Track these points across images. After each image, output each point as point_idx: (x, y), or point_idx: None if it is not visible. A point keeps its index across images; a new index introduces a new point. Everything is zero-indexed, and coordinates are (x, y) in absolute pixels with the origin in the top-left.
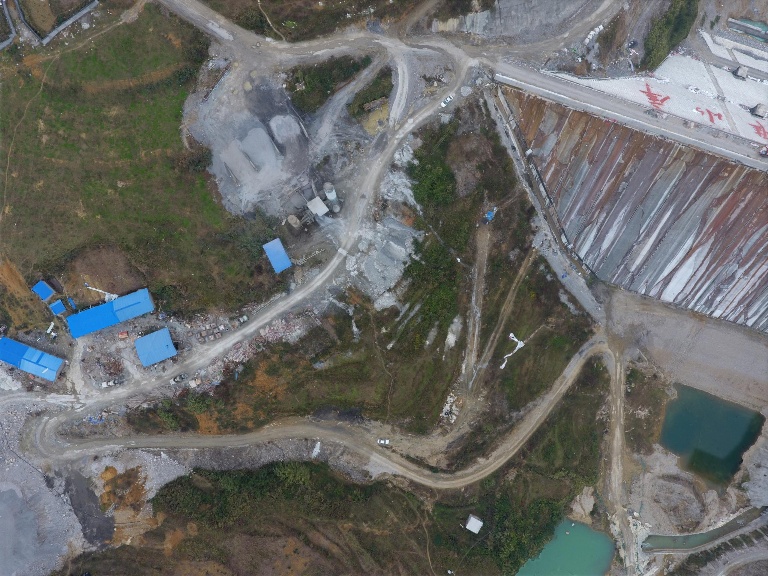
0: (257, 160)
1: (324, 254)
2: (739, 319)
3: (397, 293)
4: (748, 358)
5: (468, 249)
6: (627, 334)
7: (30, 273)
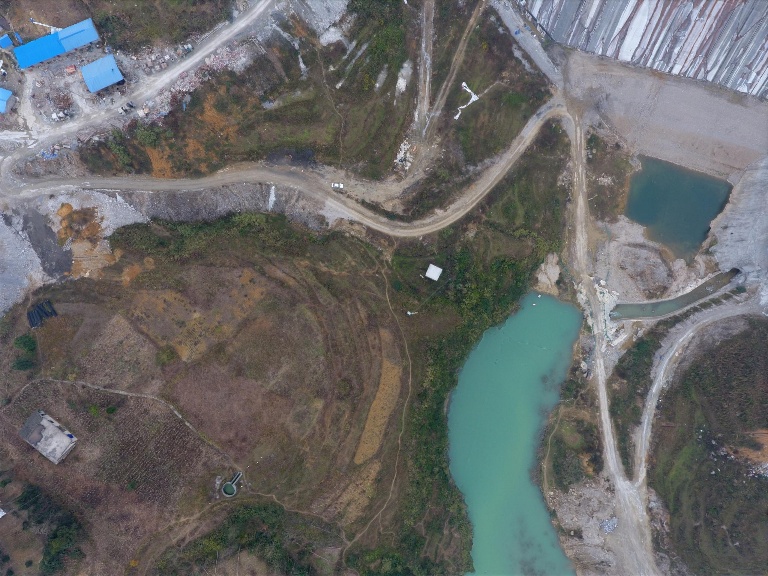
0: None
1: None
2: (699, 74)
3: (343, 29)
4: (711, 117)
5: None
6: (586, 97)
7: None
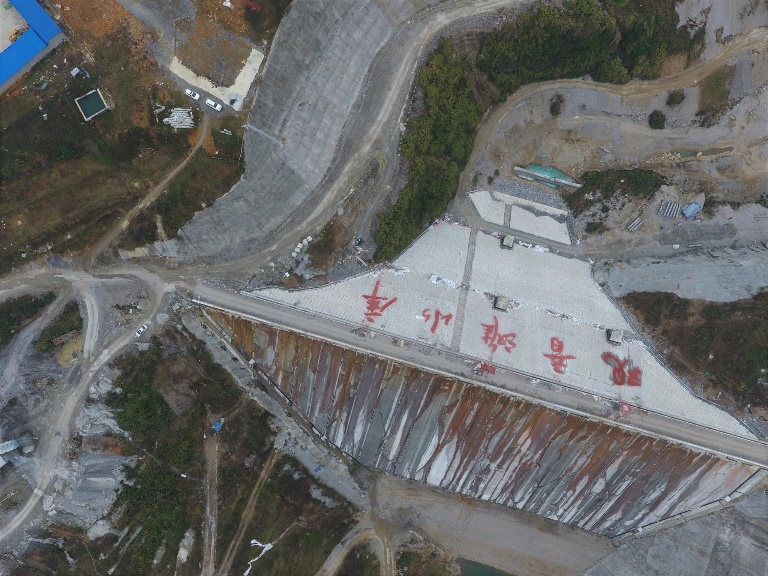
0: None
1: (19, 495)
2: (508, 502)
3: (112, 520)
4: (523, 539)
5: (196, 462)
6: (395, 518)
7: None
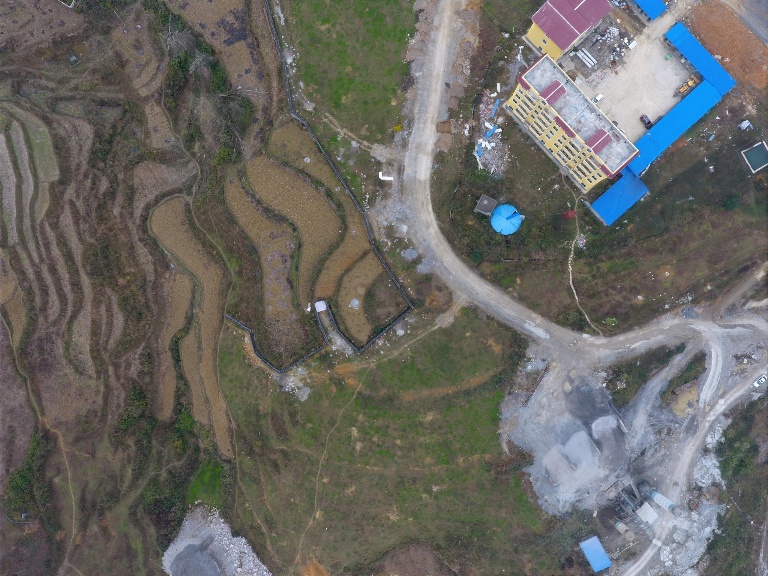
0: (573, 457)
1: (638, 546)
2: None
3: (699, 568)
4: None
5: None
6: None
7: (339, 574)
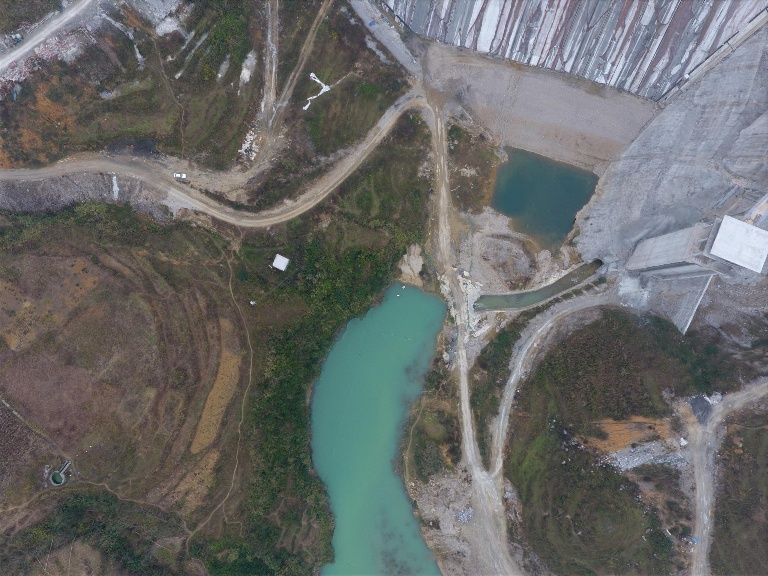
0: None
1: None
2: (557, 65)
3: (180, 19)
4: (571, 108)
5: None
6: (446, 89)
7: None
